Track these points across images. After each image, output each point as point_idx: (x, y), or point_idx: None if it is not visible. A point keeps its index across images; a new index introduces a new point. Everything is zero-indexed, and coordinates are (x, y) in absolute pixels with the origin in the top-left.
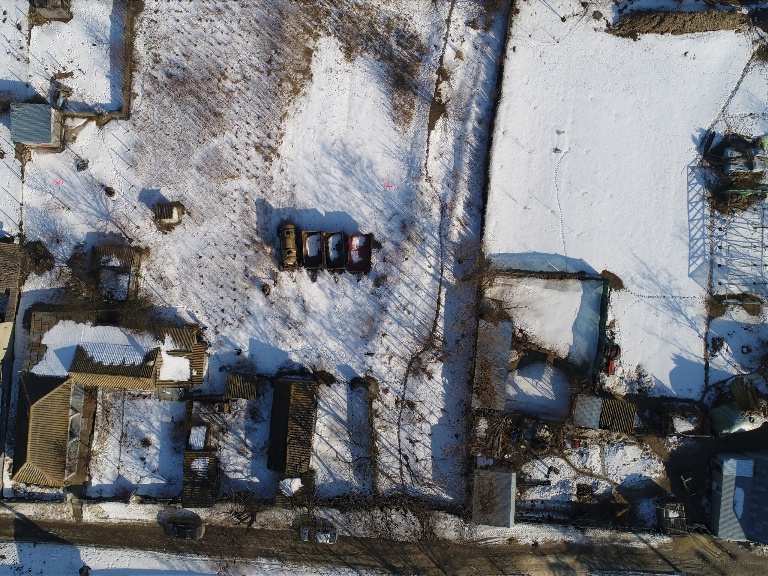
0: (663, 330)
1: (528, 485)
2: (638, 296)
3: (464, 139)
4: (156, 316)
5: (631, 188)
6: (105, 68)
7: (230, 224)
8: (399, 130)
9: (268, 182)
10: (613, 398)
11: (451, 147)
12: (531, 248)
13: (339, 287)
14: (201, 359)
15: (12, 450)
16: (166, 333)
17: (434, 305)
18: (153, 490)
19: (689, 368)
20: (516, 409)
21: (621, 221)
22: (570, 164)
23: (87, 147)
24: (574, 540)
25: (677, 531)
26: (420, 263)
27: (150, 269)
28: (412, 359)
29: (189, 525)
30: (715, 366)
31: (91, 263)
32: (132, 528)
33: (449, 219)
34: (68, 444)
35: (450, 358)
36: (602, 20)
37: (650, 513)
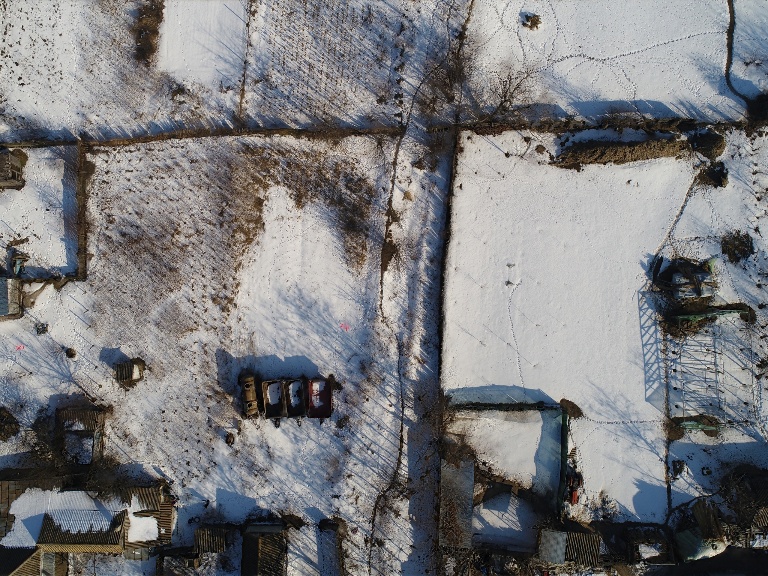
0: (624, 455)
1: None
2: (597, 423)
3: (417, 278)
4: (122, 474)
5: (584, 316)
6: (60, 232)
7: (191, 377)
8: (353, 272)
9: (226, 332)
10: (578, 527)
11: (405, 286)
12: (489, 381)
13: (302, 430)
14: (168, 517)
15: None
16: (132, 494)
17: (397, 443)
18: None
19: (652, 492)
20: (484, 542)
21: (576, 349)
22: (523, 296)
23: (46, 310)
24: None
25: None
26: (381, 403)
27: (114, 427)
28: (379, 497)
29: None
30: (677, 489)
31: (55, 426)
32: None
33: (407, 358)
34: None
35: (416, 495)
36: (545, 153)
37: None
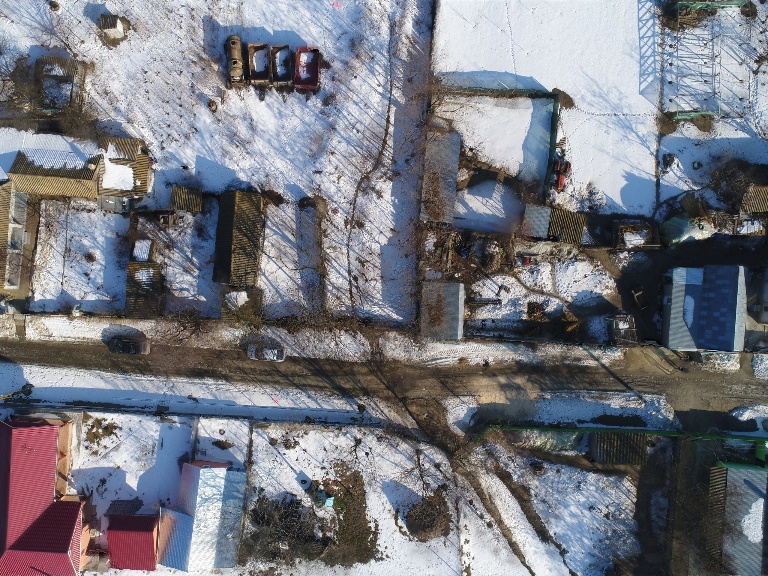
0: (614, 148)
1: (478, 303)
2: (589, 114)
3: None
4: (100, 129)
5: (581, 6)
6: None
7: (176, 40)
8: None
9: None
10: None
11: None
12: (481, 67)
13: (287, 106)
14: (145, 169)
15: None
16: (109, 142)
17: (383, 124)
18: (97, 307)
19: (640, 185)
20: (466, 228)
21: (571, 39)
22: None
23: None
24: (525, 359)
25: (627, 341)
26: (369, 81)
27: (95, 84)
28: (361, 179)
29: (133, 340)
30: (666, 182)
31: (35, 76)
32: (76, 347)
33: (398, 37)
34: (9, 251)
35: (400, 177)
36: None
37: (601, 330)
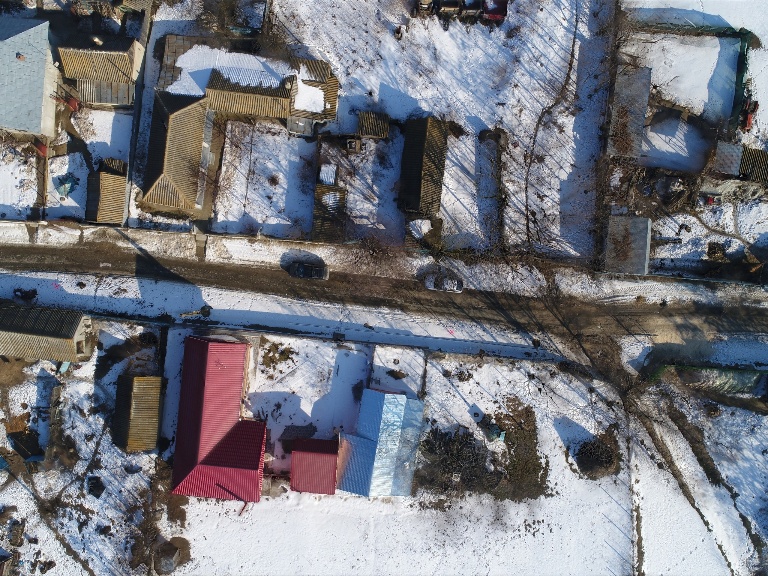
0: None
1: (659, 242)
2: None
3: None
4: None
5: None
6: None
7: None
8: None
9: None
10: None
11: None
12: (668, 4)
13: (471, 37)
14: (335, 93)
15: (140, 178)
16: (301, 64)
17: (567, 58)
18: (278, 231)
19: None
20: (648, 166)
21: None
22: None
23: None
24: (704, 300)
25: None
26: (555, 14)
27: (282, 6)
28: (543, 113)
29: (315, 265)
30: None
31: None
32: (255, 271)
33: None
34: None
35: (582, 113)
36: None
37: None
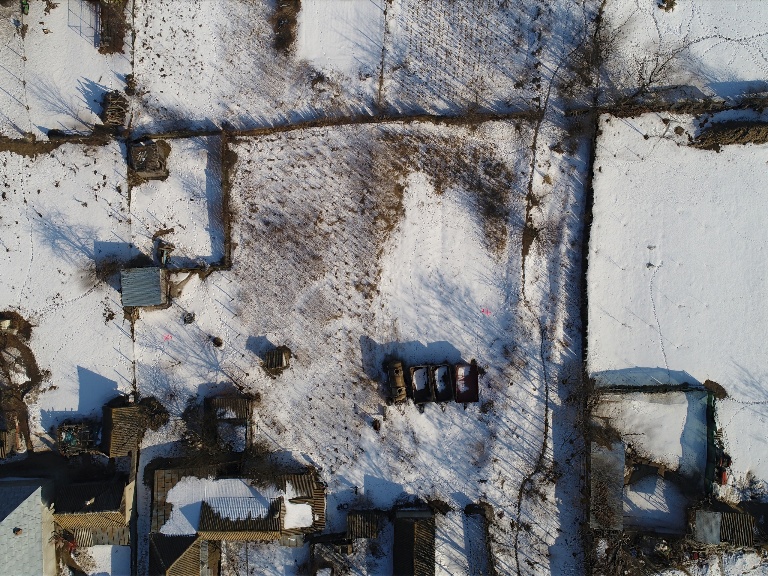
0: None
1: None
2: (743, 403)
3: (558, 262)
4: (273, 462)
5: (726, 297)
6: (204, 221)
7: (336, 364)
8: (493, 257)
9: (370, 319)
10: (728, 508)
11: (545, 270)
12: (633, 363)
13: (447, 416)
14: (322, 503)
15: None
16: (286, 481)
17: (542, 427)
18: None
19: None
20: (631, 524)
21: (719, 330)
22: (664, 278)
23: (192, 300)
24: None
25: None
26: (525, 387)
27: (262, 415)
28: (524, 481)
29: None
30: None
31: (205, 414)
32: None
33: (550, 342)
34: None
35: (562, 478)
36: (684, 135)
37: None
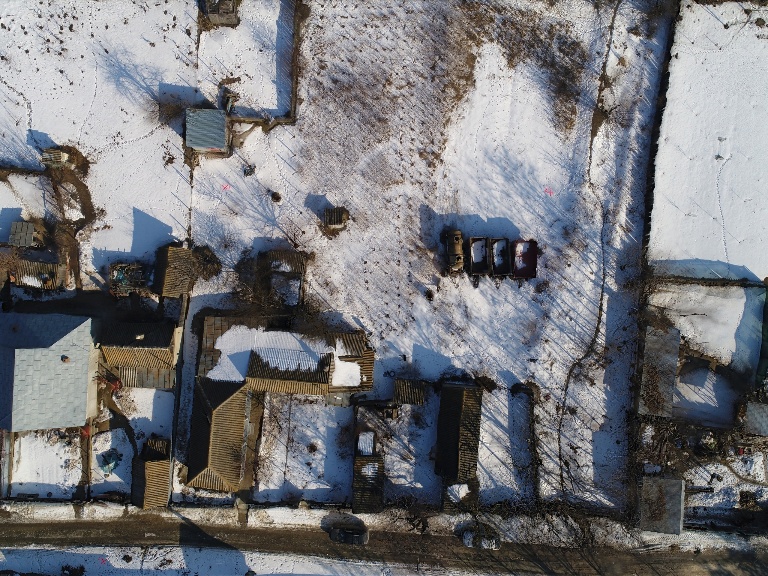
0: None
1: (691, 492)
2: None
3: (627, 146)
4: (323, 321)
5: None
6: (271, 73)
7: (394, 230)
8: (561, 136)
9: (431, 188)
10: None
11: (612, 153)
12: (693, 255)
13: (500, 293)
14: (371, 365)
15: (182, 455)
16: (337, 338)
17: (596, 311)
18: (318, 495)
19: None
20: (678, 416)
21: None
22: (732, 171)
23: (253, 152)
24: (737, 547)
25: None
26: (583, 269)
27: (316, 274)
28: (573, 365)
29: (356, 530)
30: None
31: None
32: (296, 533)
33: (612, 225)
34: None
35: (612, 364)
36: (765, 27)
37: None
